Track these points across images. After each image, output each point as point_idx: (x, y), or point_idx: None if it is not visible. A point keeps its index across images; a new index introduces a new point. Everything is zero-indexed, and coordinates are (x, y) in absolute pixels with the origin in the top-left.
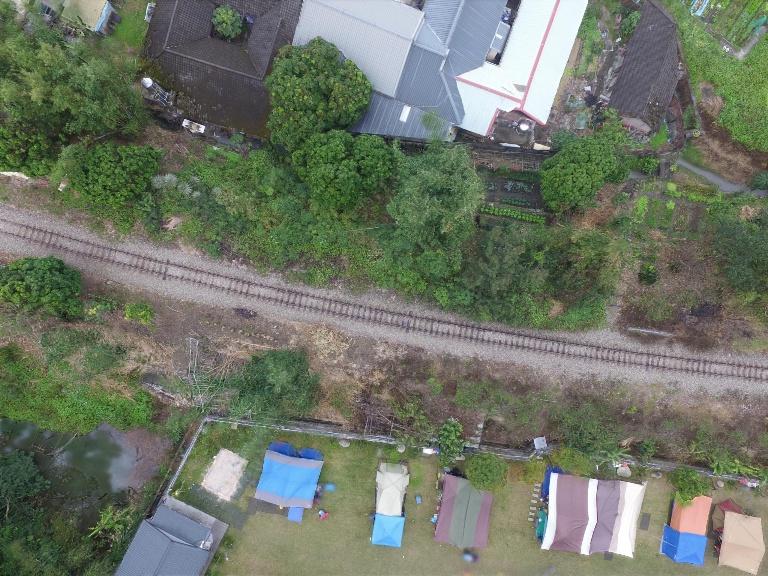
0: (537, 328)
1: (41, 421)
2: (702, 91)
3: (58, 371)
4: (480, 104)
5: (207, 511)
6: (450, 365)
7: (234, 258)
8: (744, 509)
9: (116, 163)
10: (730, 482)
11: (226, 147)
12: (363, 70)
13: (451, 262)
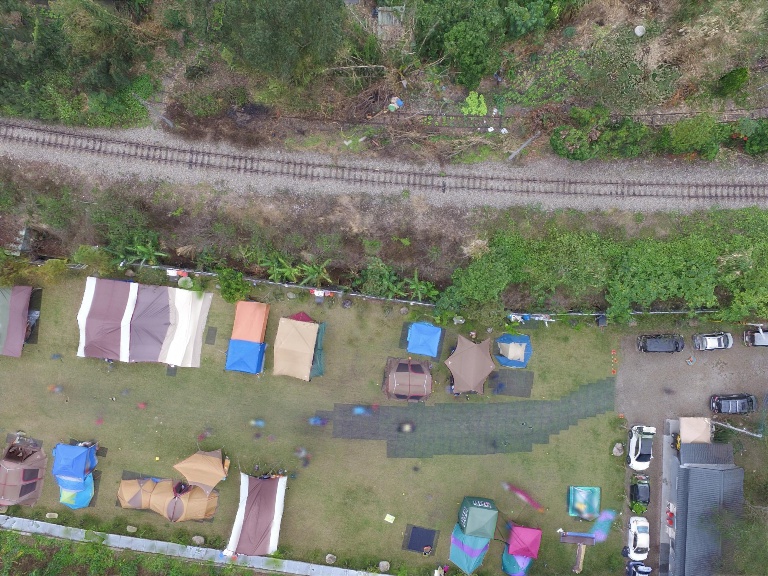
0: (70, 124)
1: None
2: None
3: None
4: None
5: None
6: None
7: None
8: (318, 322)
9: None
10: (300, 293)
11: None
12: None
13: None
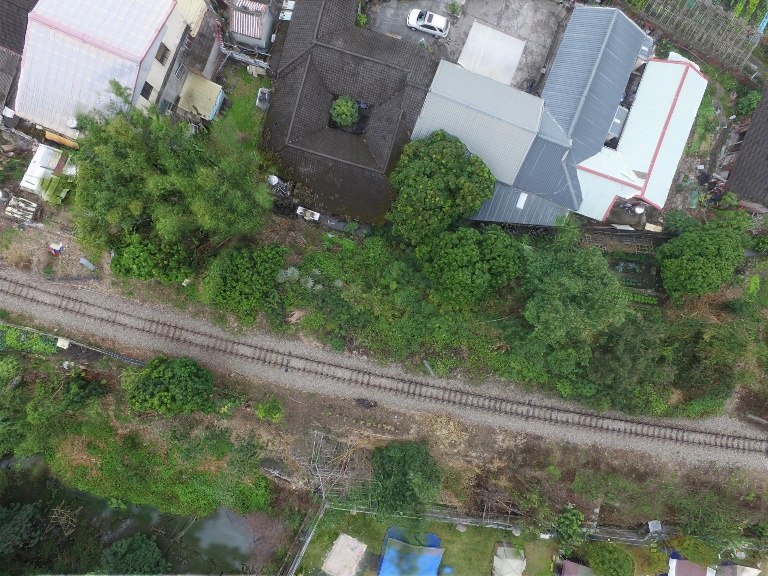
0: (656, 416)
1: (162, 506)
2: None
3: (179, 458)
4: (599, 191)
5: None
6: (569, 453)
7: (355, 349)
8: None
9: (252, 269)
10: None
11: (340, 234)
12: (483, 160)
13: (580, 359)
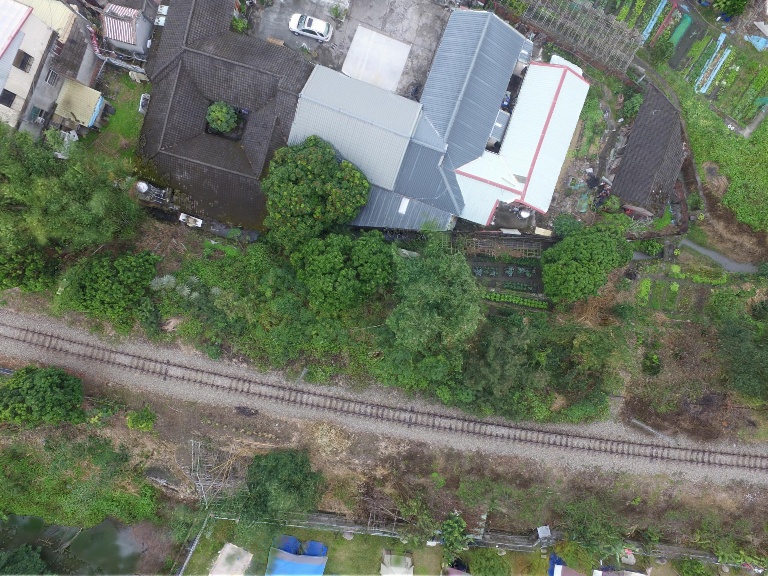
0: (540, 421)
1: (47, 517)
2: (707, 170)
3: (62, 468)
4: (480, 195)
5: None
6: (453, 460)
7: (234, 357)
8: None
9: (113, 277)
10: (735, 567)
11: (224, 241)
12: (361, 165)
13: (452, 366)
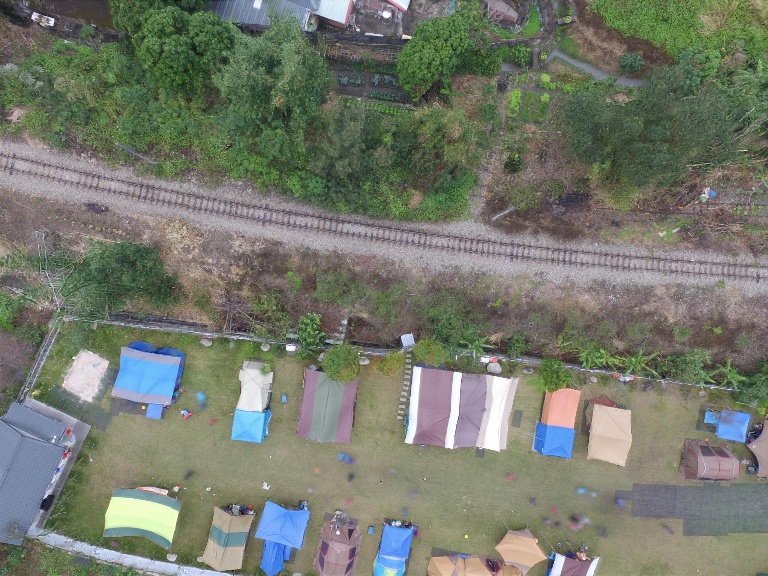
0: (397, 219)
1: None
2: None
3: None
4: None
5: (69, 412)
6: (308, 258)
7: (83, 151)
8: (618, 405)
9: None
10: (603, 377)
11: (78, 41)
12: None
13: (294, 144)
